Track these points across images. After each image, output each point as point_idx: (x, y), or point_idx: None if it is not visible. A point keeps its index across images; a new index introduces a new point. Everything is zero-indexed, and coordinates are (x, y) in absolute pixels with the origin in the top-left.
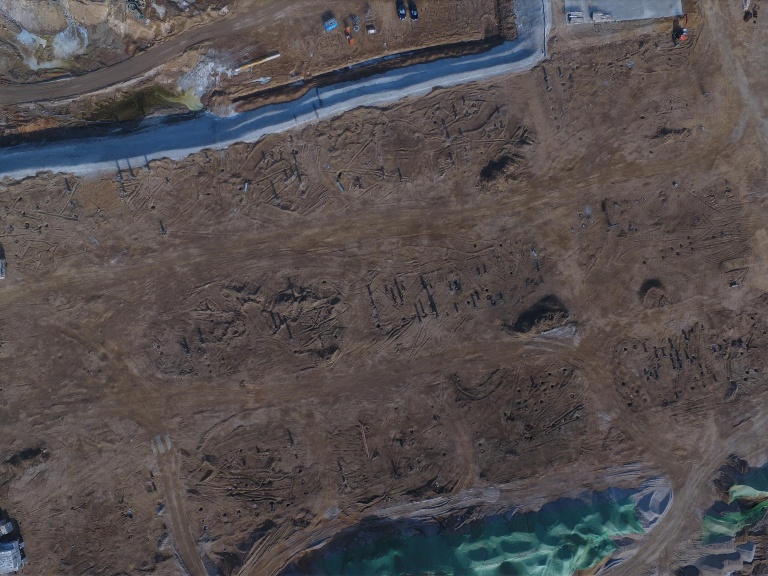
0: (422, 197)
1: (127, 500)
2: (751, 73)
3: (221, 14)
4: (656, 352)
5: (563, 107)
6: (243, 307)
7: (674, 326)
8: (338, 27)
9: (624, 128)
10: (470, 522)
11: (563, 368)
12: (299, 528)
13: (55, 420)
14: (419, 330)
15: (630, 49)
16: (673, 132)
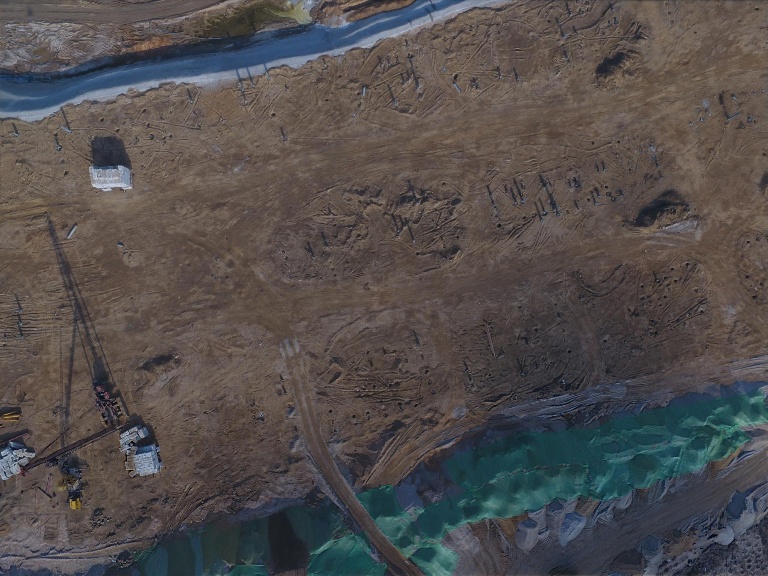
0: (538, 96)
1: (258, 403)
2: None
3: None
4: None
5: (676, 1)
6: (365, 210)
7: None
8: None
9: (739, 20)
10: (599, 418)
11: (686, 263)
12: (428, 427)
13: (185, 326)
14: (540, 228)
15: None
16: None
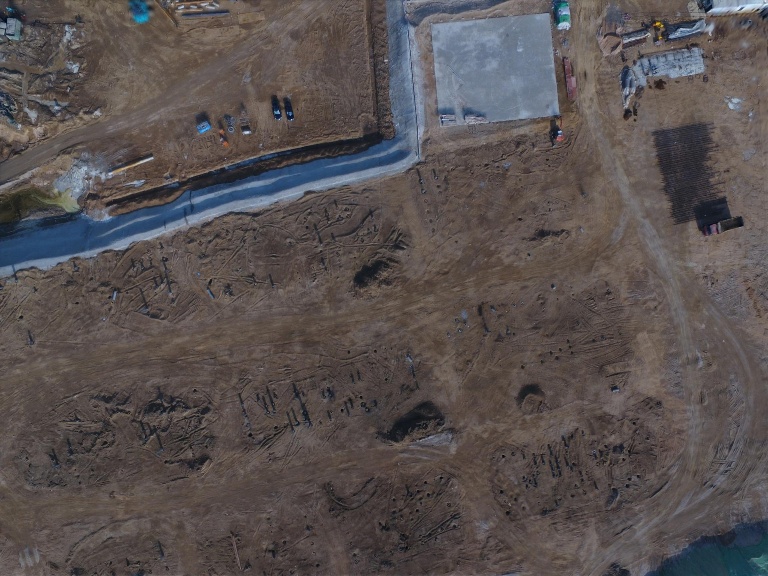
0: (294, 303)
1: None
2: (631, 172)
3: (94, 117)
4: (535, 459)
5: (438, 210)
6: (112, 418)
7: (553, 432)
8: (213, 128)
9: (501, 230)
10: None
11: (439, 476)
12: None
13: None
14: (292, 439)
15: (506, 150)
16: (551, 234)
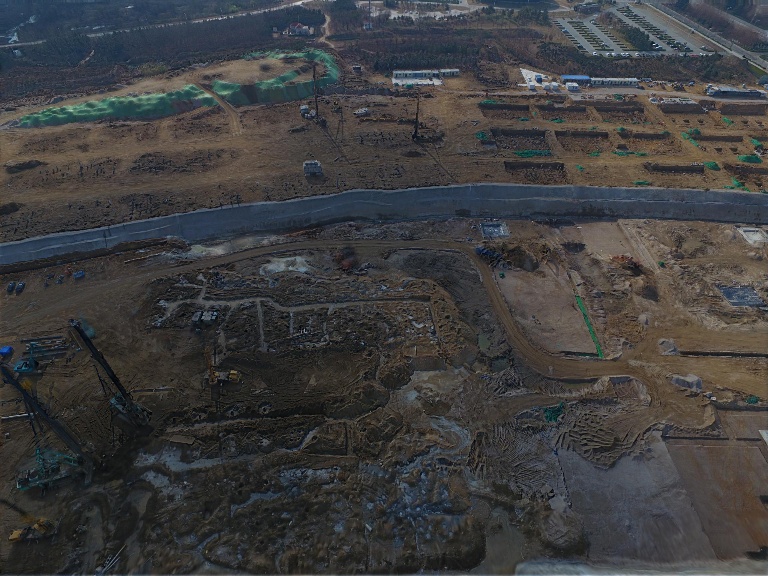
0: (62, 201)
1: None
2: None
3: None
4: None
5: None
6: None
7: None
8: None
9: None
10: None
11: None
12: None
13: None
14: None
15: None
16: None
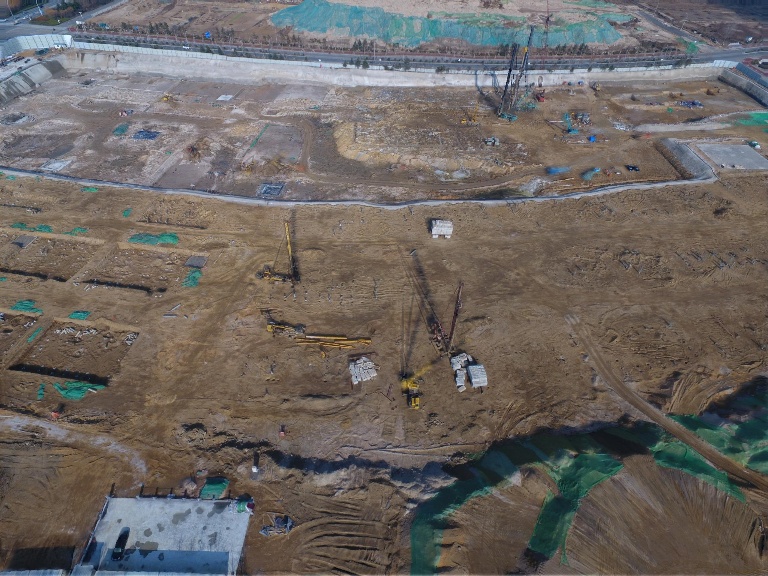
0: (685, 220)
1: (557, 350)
2: None
3: (539, 166)
4: None
5: (742, 194)
6: (601, 256)
7: None
8: (600, 172)
9: None
10: None
11: None
12: (705, 377)
13: (492, 302)
14: (723, 273)
15: (762, 178)
16: None
